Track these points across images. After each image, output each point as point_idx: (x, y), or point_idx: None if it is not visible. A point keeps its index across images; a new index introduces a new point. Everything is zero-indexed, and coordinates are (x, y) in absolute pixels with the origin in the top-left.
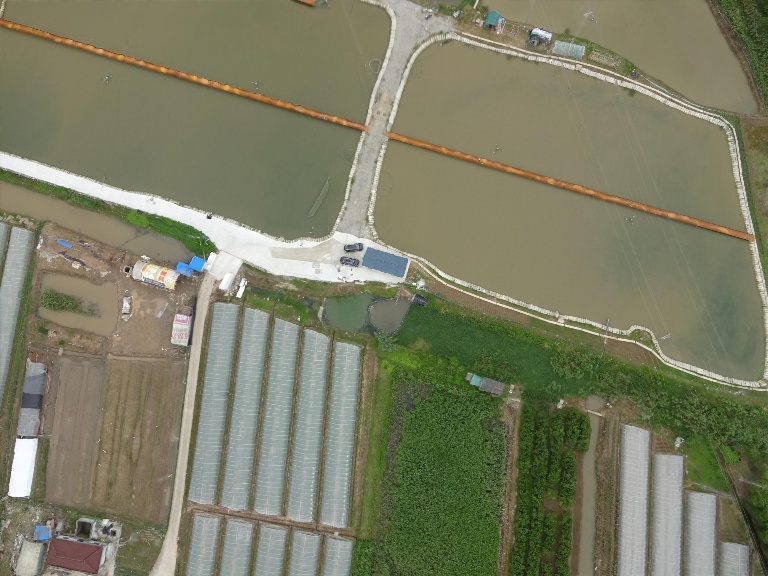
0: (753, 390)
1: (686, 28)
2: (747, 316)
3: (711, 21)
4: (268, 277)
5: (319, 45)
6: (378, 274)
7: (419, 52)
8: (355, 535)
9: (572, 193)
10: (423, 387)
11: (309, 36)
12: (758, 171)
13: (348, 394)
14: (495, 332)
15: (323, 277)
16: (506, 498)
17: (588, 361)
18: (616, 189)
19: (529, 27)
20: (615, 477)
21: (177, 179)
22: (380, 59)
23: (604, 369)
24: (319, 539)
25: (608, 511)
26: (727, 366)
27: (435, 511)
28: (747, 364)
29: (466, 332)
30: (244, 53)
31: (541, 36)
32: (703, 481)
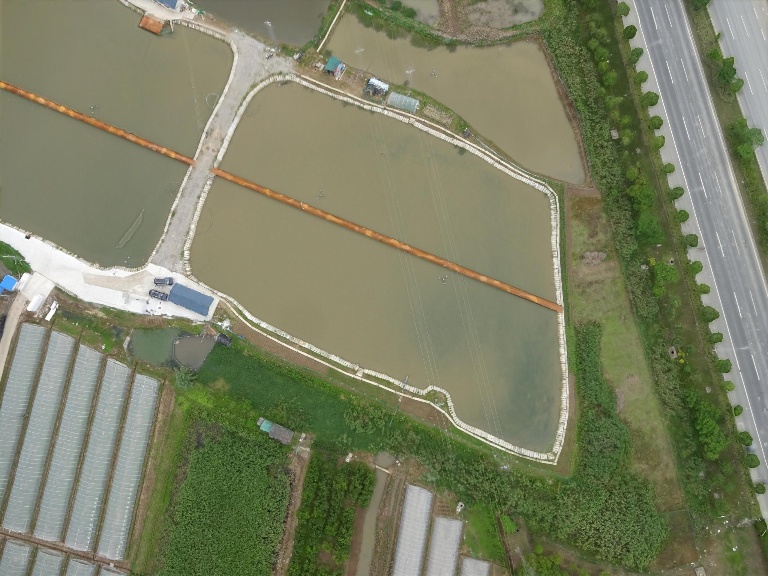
0: (540, 462)
1: (525, 91)
2: (545, 387)
3: (551, 86)
4: (78, 302)
5: (159, 75)
6: (185, 310)
7: (257, 91)
8: (130, 568)
9: (389, 247)
10: (216, 427)
11: (150, 65)
12: (577, 242)
13: (139, 427)
14: (294, 379)
15: (131, 308)
16: (283, 546)
17: (381, 417)
18: (433, 247)
19: (369, 76)
20: (393, 536)
21: (2, 196)
22: (218, 94)
23: (397, 426)
24: (93, 569)
25: (381, 569)
26: (518, 435)
27: (209, 552)
28: (539, 435)
29: (266, 376)
30: (85, 75)
31: (377, 86)
32: (479, 548)
